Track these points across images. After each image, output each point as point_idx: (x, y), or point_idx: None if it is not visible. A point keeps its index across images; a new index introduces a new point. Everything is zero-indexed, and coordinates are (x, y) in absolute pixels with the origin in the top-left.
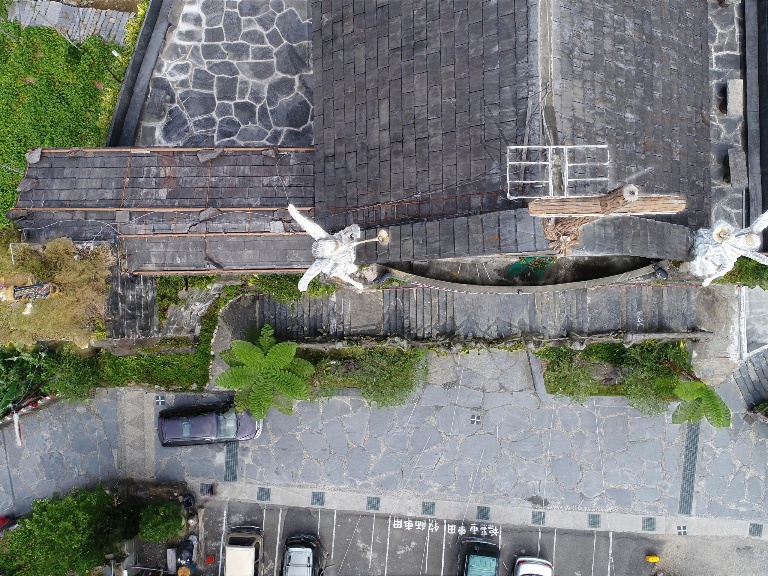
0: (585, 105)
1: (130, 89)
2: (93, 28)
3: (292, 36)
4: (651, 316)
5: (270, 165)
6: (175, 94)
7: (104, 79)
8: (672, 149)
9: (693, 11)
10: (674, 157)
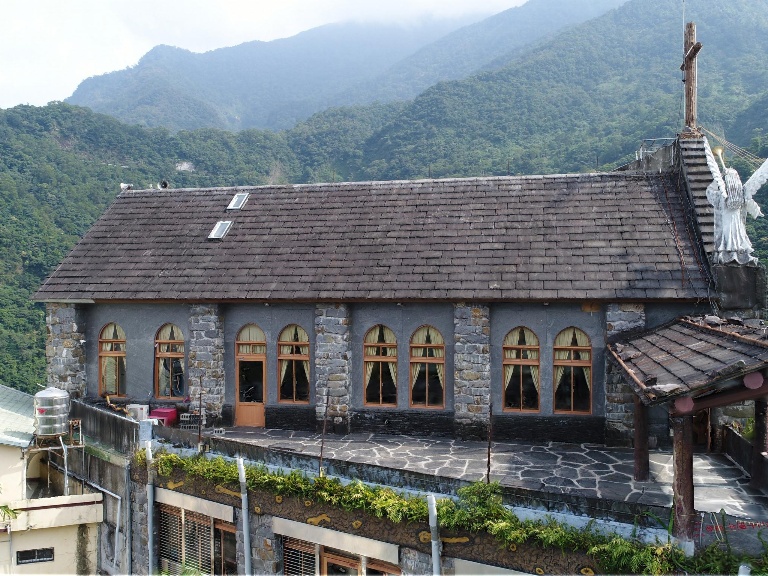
0: None
1: None
2: None
3: (441, 452)
4: None
5: None
6: None
7: None
8: None
9: None
10: None
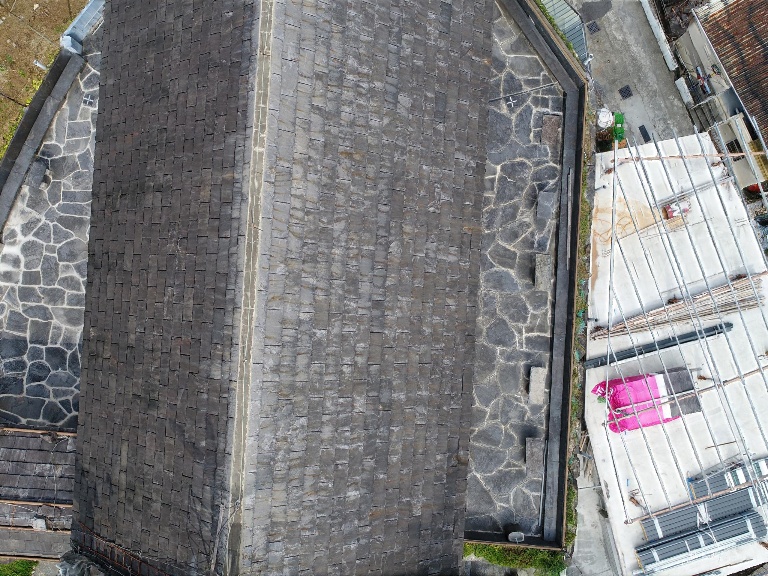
0: (289, 505)
1: None
2: None
3: None
4: (463, 568)
5: (46, 450)
6: None
7: None
8: (412, 505)
9: (454, 355)
10: (414, 513)
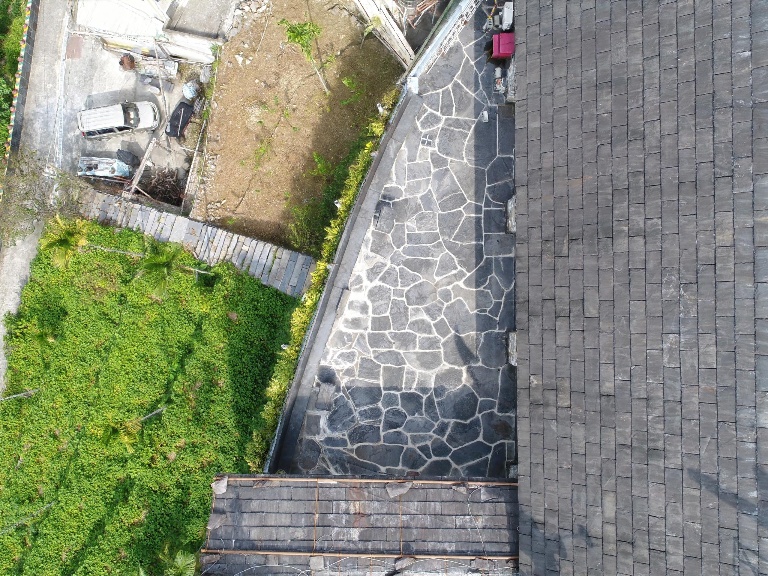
0: None
1: (298, 383)
2: (224, 252)
3: (460, 326)
4: None
5: (461, 502)
6: (340, 383)
7: (238, 311)
8: None
9: None
10: None
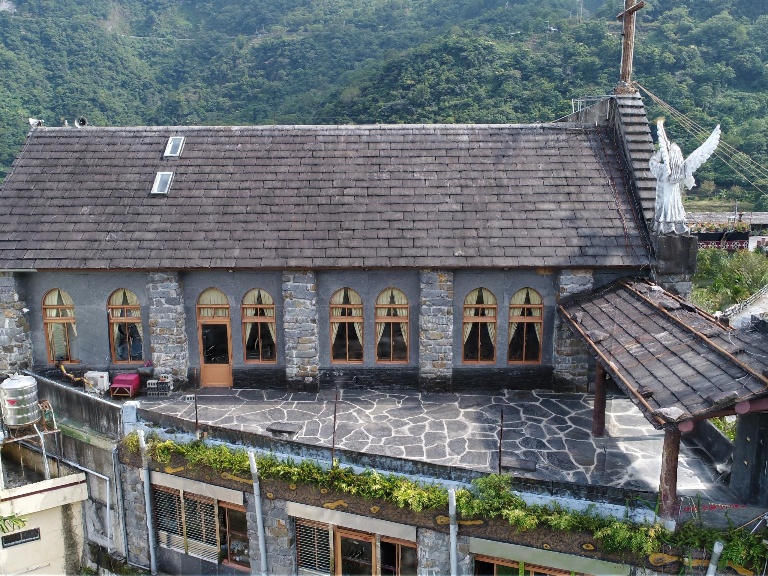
0: None
1: None
2: None
3: (416, 412)
4: None
5: None
6: None
7: None
8: None
9: None
10: None
